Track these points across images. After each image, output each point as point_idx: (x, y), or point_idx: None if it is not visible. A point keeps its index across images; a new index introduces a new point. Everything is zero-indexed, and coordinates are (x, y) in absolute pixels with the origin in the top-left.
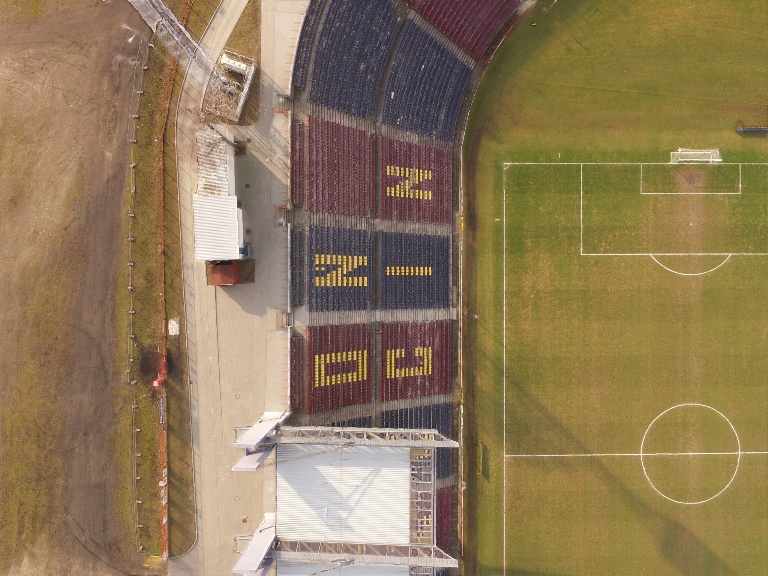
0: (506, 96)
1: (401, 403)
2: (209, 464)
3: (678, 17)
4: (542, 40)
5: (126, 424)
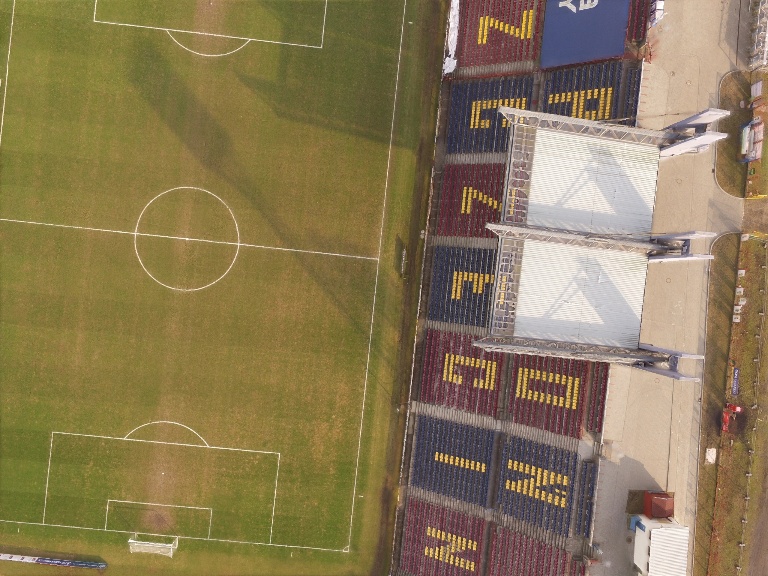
0: None
1: (483, 333)
2: (692, 318)
3: None
4: None
5: (766, 367)
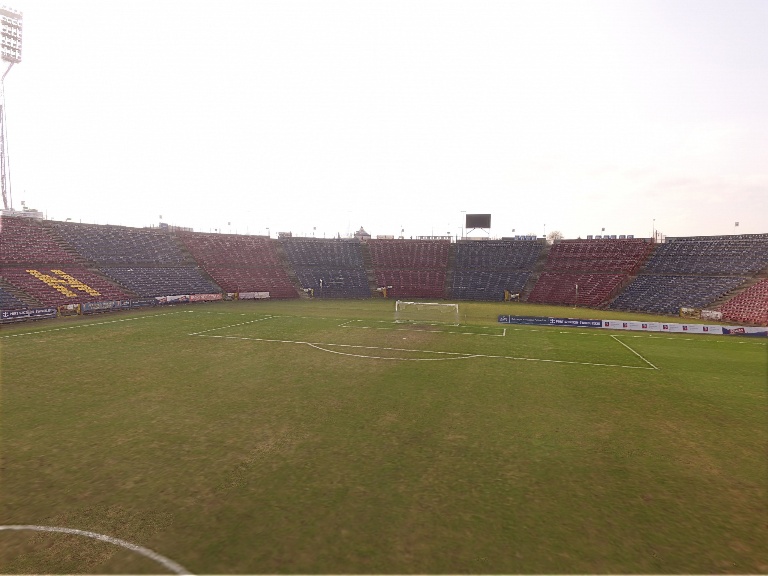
0: None
1: None
2: None
3: None
4: None
5: None
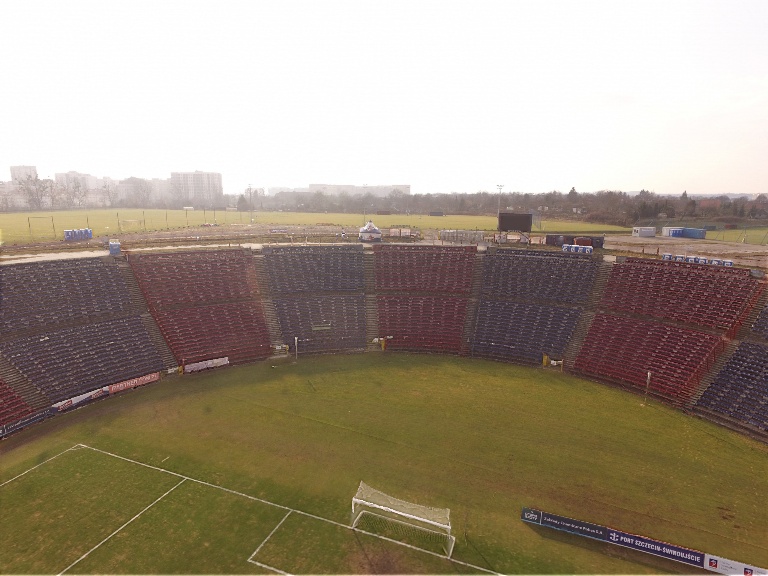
0: (177, 396)
1: None
2: None
3: (451, 392)
4: (271, 375)
5: None
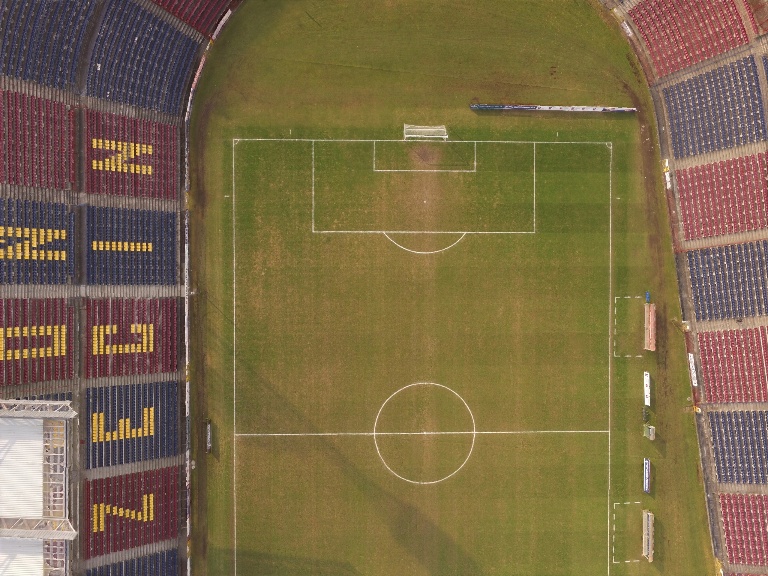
0: (236, 71)
1: (114, 380)
2: None
3: None
4: (273, 14)
5: None
